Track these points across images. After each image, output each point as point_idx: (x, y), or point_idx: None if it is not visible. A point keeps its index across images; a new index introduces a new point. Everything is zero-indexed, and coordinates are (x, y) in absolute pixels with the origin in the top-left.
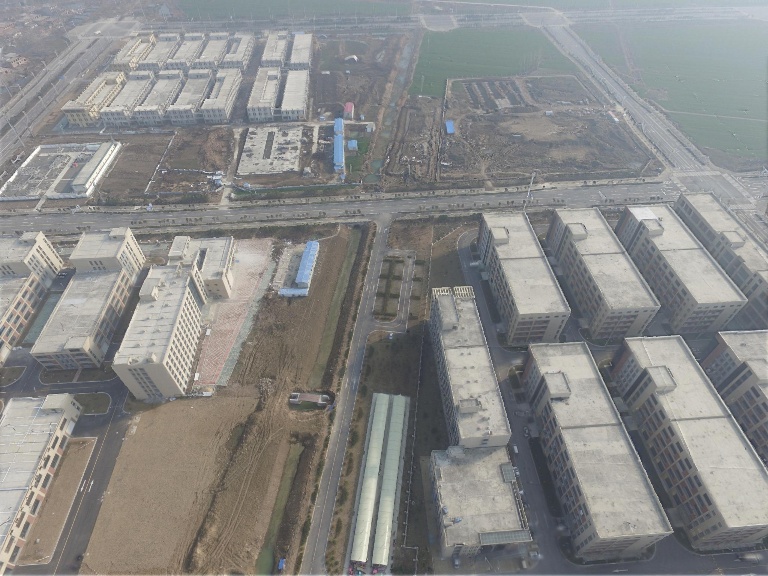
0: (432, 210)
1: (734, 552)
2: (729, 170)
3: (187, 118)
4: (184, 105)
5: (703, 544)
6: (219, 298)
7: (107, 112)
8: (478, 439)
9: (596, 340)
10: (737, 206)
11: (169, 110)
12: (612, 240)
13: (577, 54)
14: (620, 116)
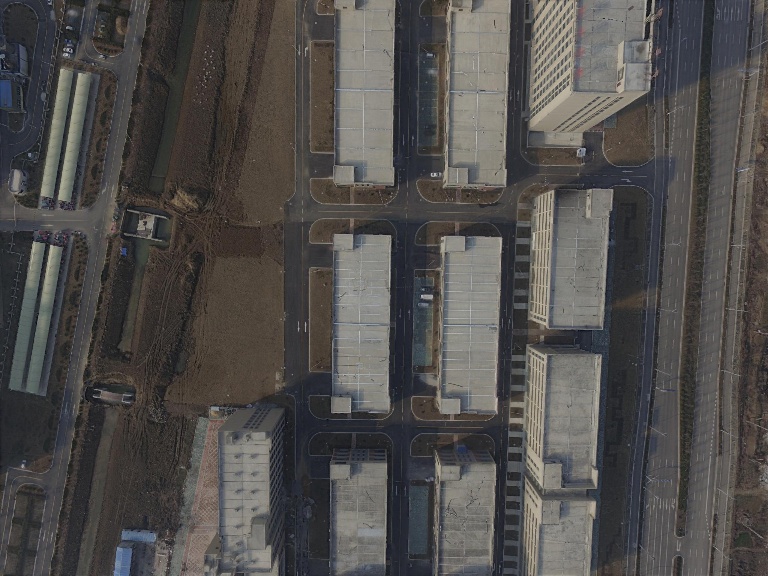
0: None
1: None
2: None
3: None
4: None
5: None
6: None
7: None
8: None
9: None
10: None
11: None
12: None
13: None
14: None
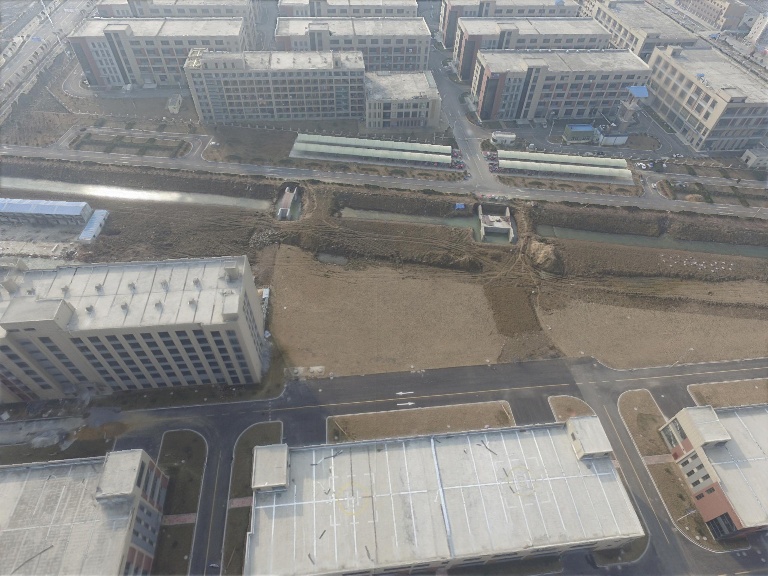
0: None
1: None
2: None
3: None
4: None
5: None
6: None
7: None
8: None
9: (256, 49)
10: None
11: None
12: None
13: None
14: None
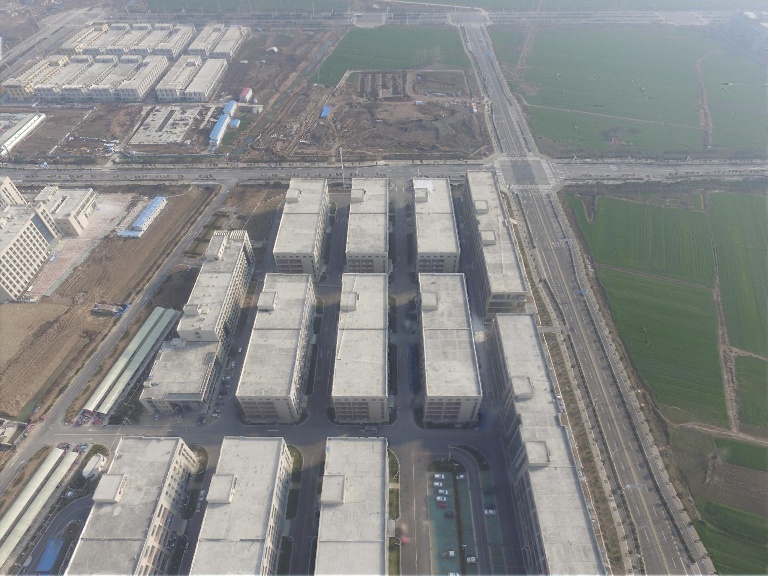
0: (273, 178)
1: (363, 425)
2: (549, 157)
3: (106, 96)
4: (104, 85)
5: (342, 418)
6: (71, 235)
7: (39, 88)
8: (191, 333)
9: None
10: (536, 186)
11: (90, 89)
12: (384, 203)
13: (478, 52)
14: (482, 108)
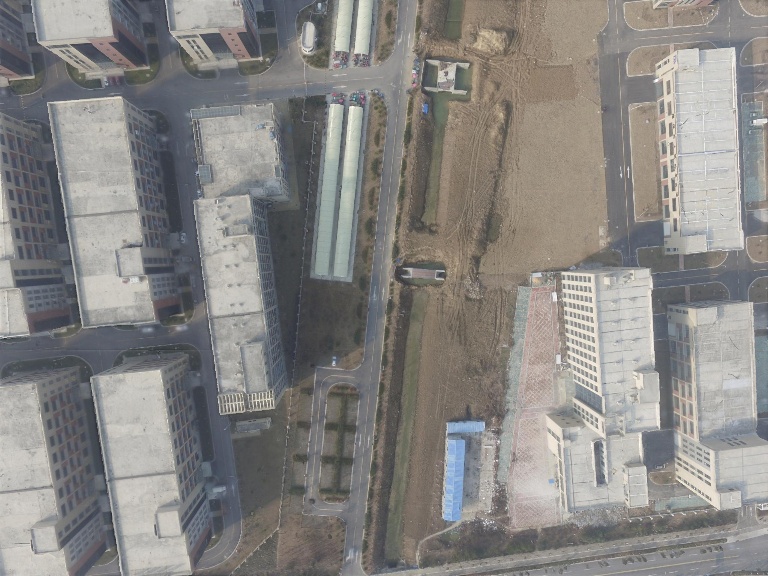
0: None
1: None
2: None
3: None
4: None
5: None
6: (559, 414)
7: None
8: None
9: (75, 365)
10: None
11: None
12: None
13: None
14: None
